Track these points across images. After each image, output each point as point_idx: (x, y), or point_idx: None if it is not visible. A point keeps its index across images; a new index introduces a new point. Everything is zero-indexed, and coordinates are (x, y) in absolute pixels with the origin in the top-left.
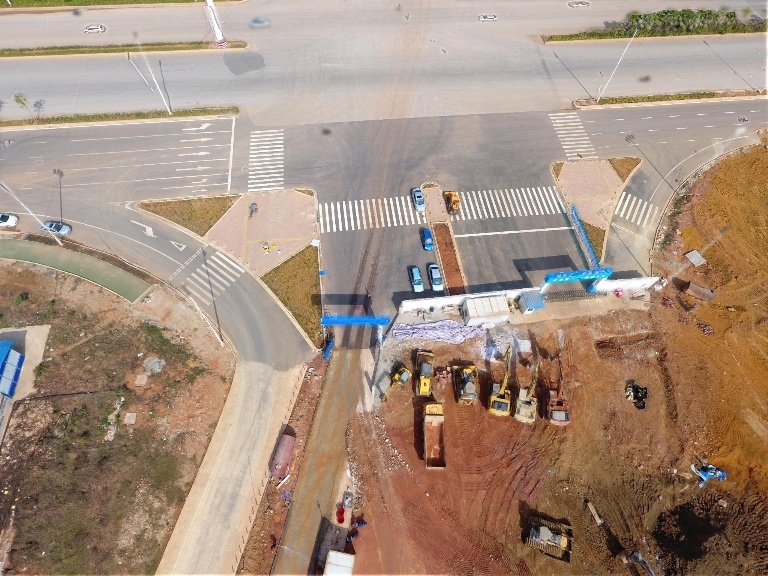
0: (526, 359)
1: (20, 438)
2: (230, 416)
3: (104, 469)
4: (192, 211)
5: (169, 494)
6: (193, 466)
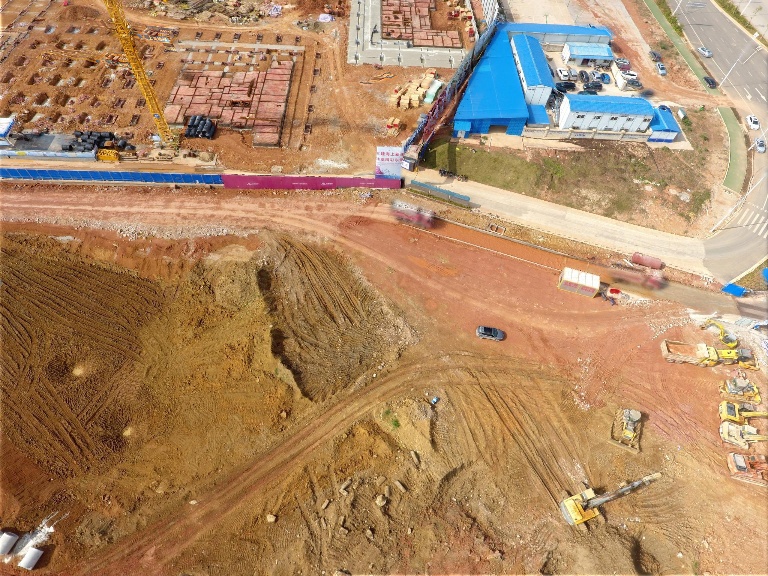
0: None
1: (627, 147)
2: (662, 236)
3: (619, 180)
4: None
5: (610, 209)
6: (627, 219)
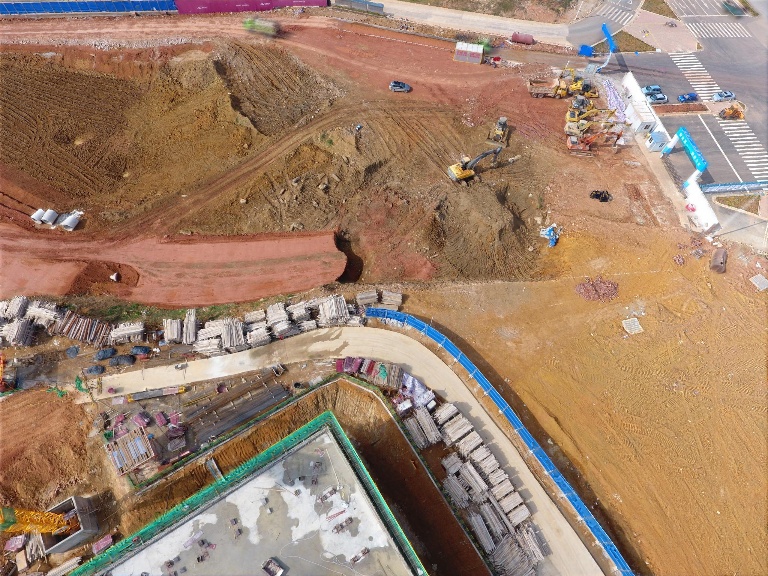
0: (609, 140)
1: None
2: (537, 24)
3: None
4: (657, 4)
5: (497, 9)
6: (510, 16)
